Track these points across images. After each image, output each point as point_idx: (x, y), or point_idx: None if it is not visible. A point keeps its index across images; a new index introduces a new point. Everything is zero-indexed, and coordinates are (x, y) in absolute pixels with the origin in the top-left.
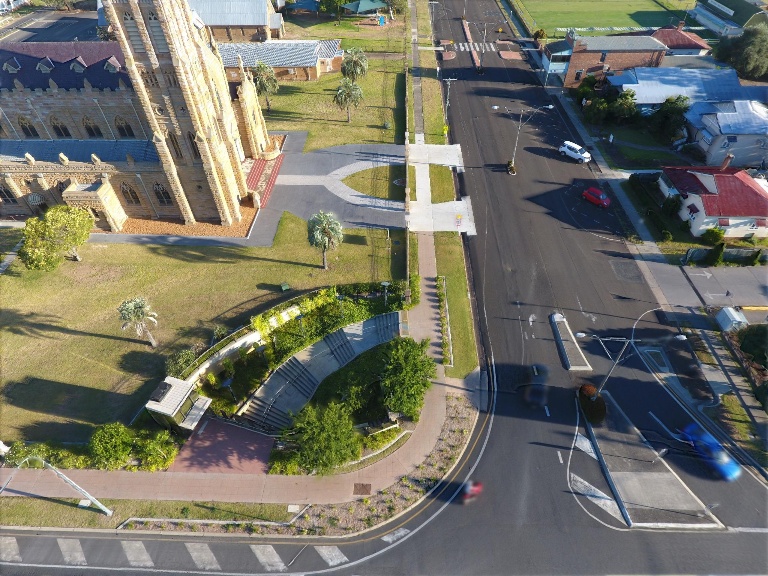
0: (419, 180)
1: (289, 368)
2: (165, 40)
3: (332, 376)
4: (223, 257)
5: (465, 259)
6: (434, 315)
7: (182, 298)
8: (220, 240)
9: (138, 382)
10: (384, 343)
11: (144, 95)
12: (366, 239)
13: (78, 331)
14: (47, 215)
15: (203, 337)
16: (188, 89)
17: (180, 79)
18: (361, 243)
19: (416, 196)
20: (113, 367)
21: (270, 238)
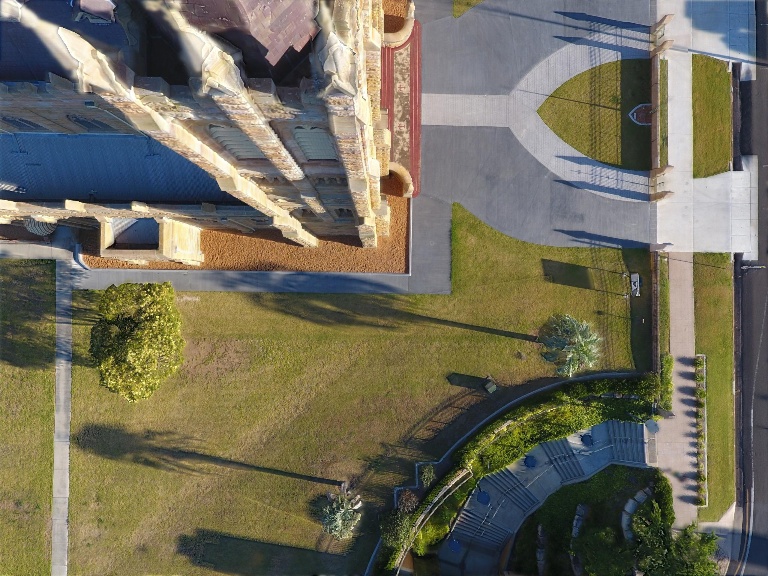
0: (674, 108)
1: (499, 478)
2: (334, 151)
3: (556, 498)
4: (384, 318)
5: (734, 313)
6: (689, 429)
7: (352, 404)
8: (368, 280)
9: (347, 539)
10: (623, 467)
11: (259, 202)
12: (592, 275)
13: (237, 463)
14: (129, 360)
15: (403, 473)
16: (368, 195)
17: (358, 197)
18: (585, 285)
19: (668, 157)
20: (309, 519)
21: (445, 274)
